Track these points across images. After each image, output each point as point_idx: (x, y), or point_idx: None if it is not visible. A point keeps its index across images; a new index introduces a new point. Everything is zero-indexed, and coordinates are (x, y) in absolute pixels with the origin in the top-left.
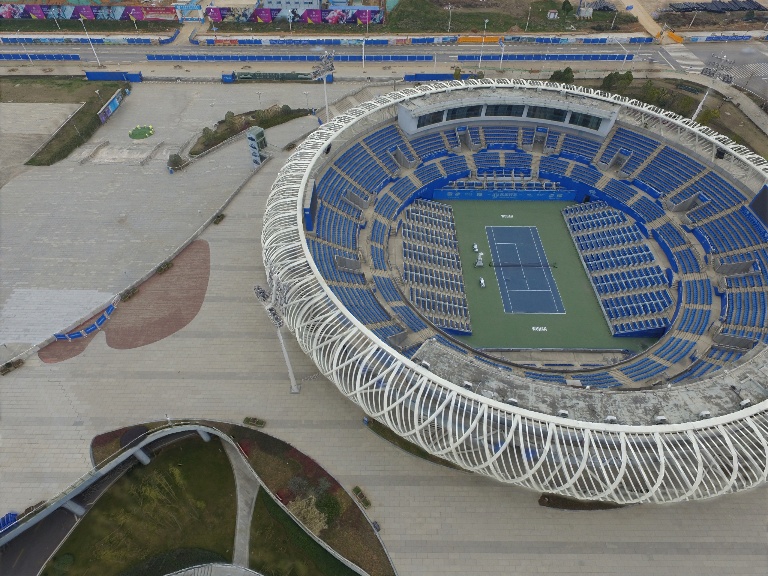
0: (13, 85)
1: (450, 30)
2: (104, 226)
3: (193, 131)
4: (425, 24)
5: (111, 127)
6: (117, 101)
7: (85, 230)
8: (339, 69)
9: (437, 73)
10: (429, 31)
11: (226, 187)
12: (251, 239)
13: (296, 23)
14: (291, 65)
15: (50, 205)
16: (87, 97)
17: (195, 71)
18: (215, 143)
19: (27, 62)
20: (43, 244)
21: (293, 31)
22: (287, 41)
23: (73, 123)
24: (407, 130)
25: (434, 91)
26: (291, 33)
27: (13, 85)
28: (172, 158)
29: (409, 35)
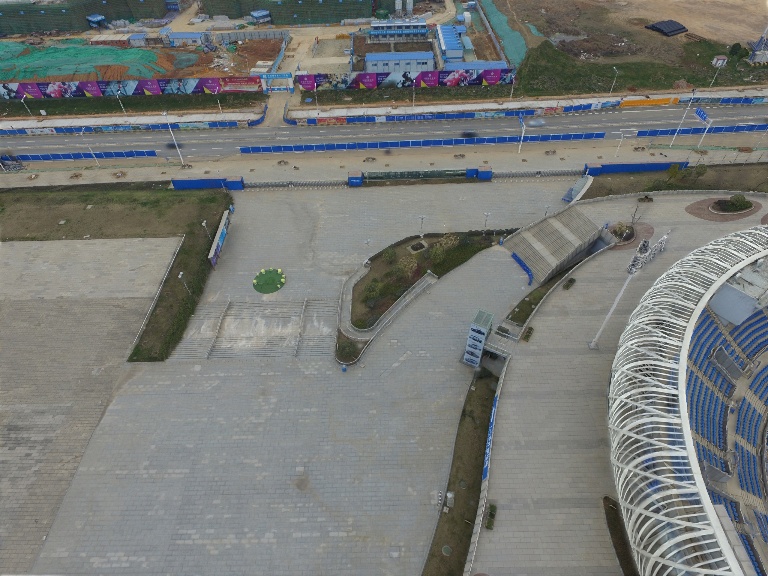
0: (84, 207)
1: (601, 89)
2: (279, 498)
3: (338, 275)
4: (566, 82)
5: (225, 272)
6: (224, 228)
7: (252, 509)
8: (489, 157)
9: (629, 162)
10: (575, 92)
11: (435, 398)
12: (565, 569)
13: (407, 88)
14: (424, 152)
15: (184, 450)
16: (184, 224)
17: (306, 168)
18: (383, 303)
19: (91, 162)
20: (194, 548)
21: (406, 99)
22: (408, 117)
23: (177, 272)
24: (730, 318)
25: (765, 254)
26: (413, 107)
27: (84, 207)
28: (346, 350)
29: (552, 99)
